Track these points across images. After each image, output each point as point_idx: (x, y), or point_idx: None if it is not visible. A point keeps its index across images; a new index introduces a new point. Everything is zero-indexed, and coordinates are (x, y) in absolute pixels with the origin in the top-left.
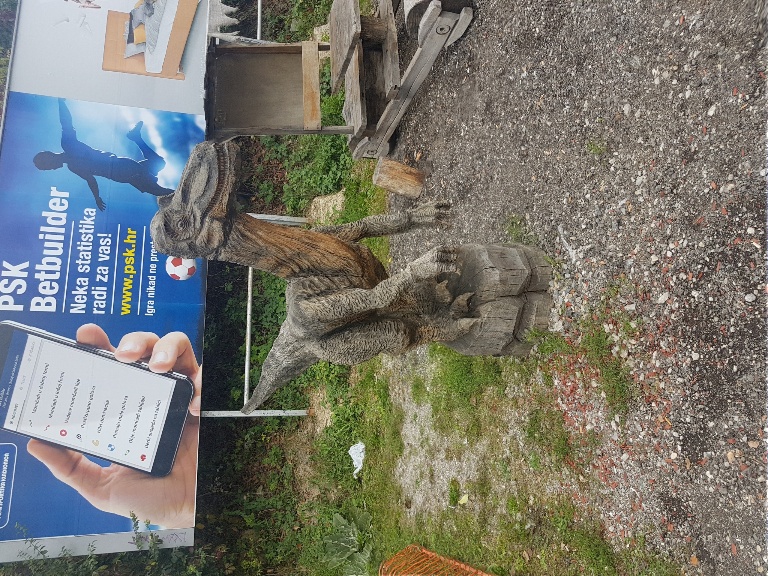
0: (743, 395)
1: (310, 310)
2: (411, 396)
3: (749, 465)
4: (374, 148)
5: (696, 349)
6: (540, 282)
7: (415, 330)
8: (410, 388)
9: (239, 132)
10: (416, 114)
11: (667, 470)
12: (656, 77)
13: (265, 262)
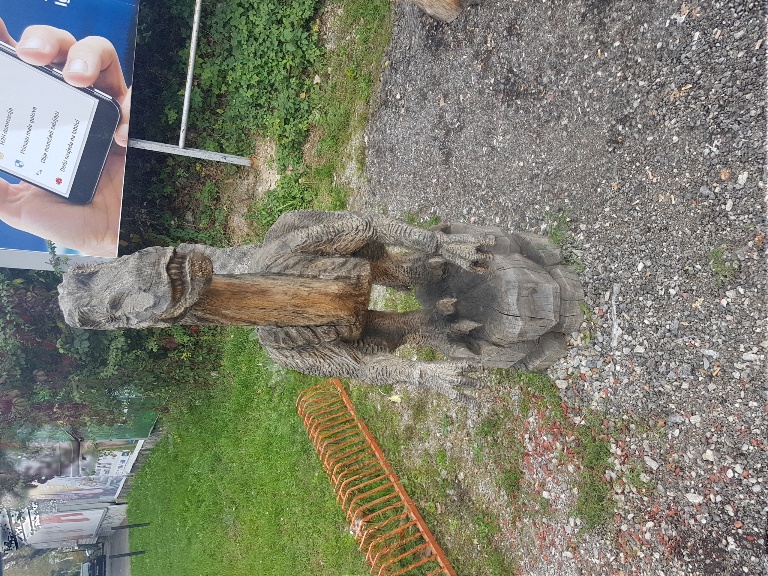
0: None
1: (279, 361)
2: None
3: None
4: None
5: None
6: (563, 331)
7: (399, 340)
8: None
9: None
10: None
11: None
12: None
13: None
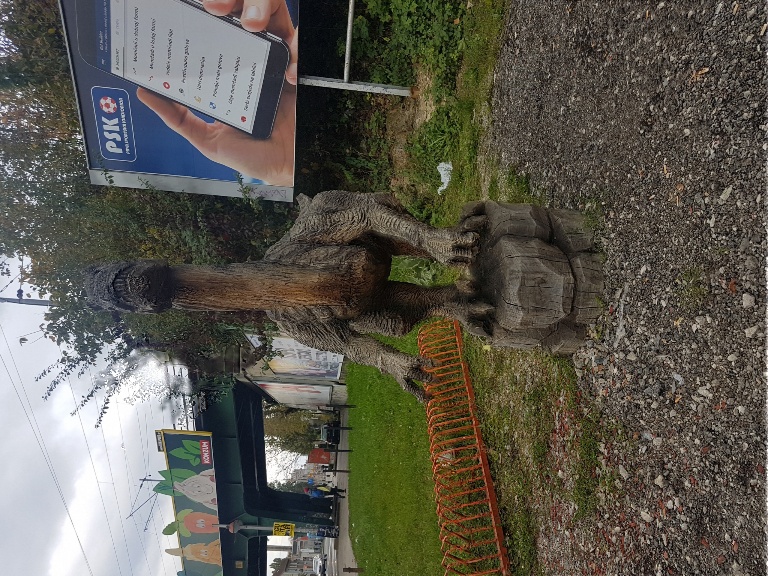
0: None
1: None
2: None
3: None
4: None
5: None
6: None
7: (423, 312)
8: (490, 178)
9: None
10: None
11: None
12: None
13: None
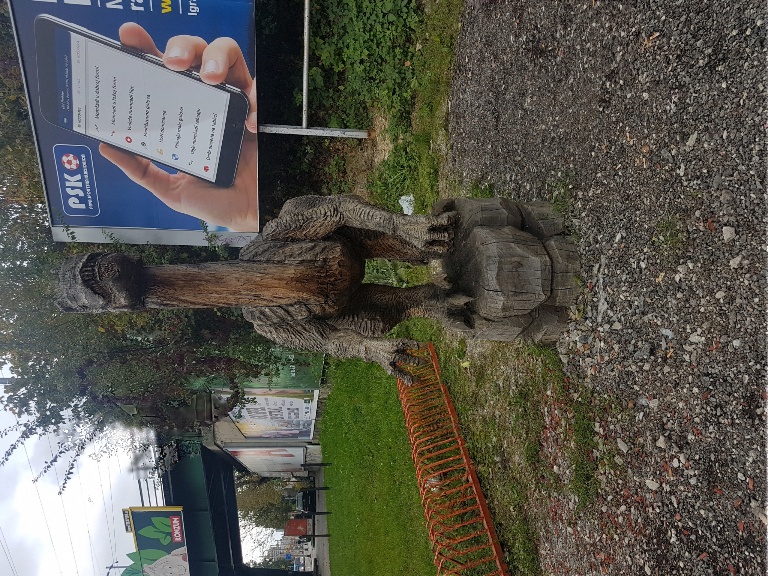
0: None
1: None
2: None
3: None
4: None
5: (651, 567)
6: (559, 305)
7: (401, 314)
8: None
9: None
10: None
11: None
12: None
13: None
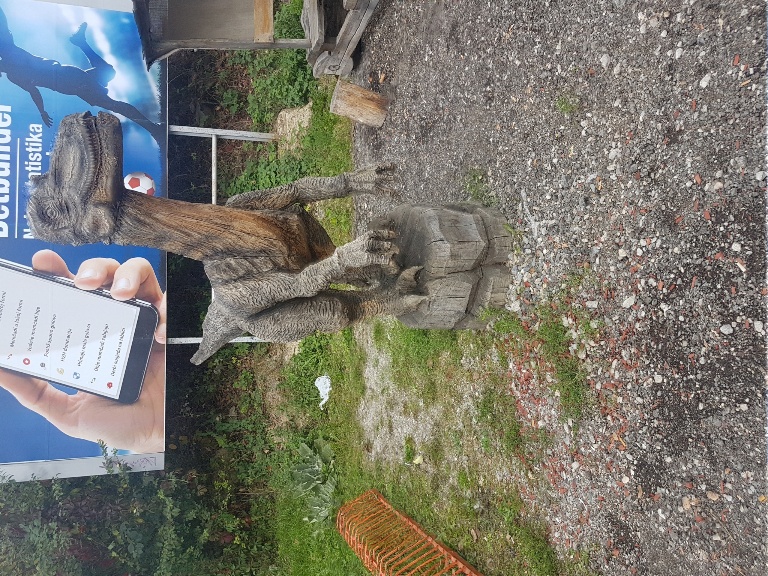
0: (706, 438)
1: (226, 298)
2: (374, 340)
3: (705, 517)
4: (336, 63)
5: (659, 371)
6: (498, 255)
7: (356, 307)
8: (373, 332)
9: (180, 45)
10: (381, 26)
11: (617, 493)
12: (642, 23)
13: (167, 247)
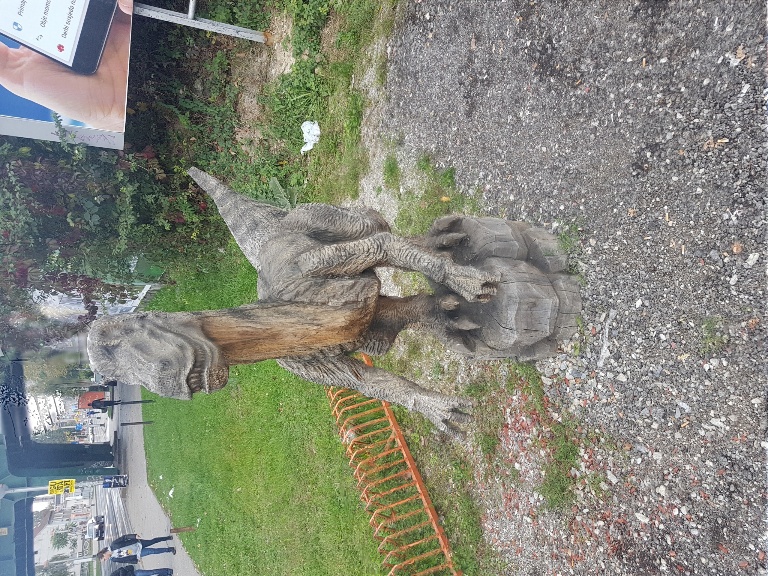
0: None
1: None
2: (382, 165)
3: None
4: None
5: None
6: None
7: None
8: (384, 156)
9: None
10: None
11: (549, 572)
12: None
13: None
